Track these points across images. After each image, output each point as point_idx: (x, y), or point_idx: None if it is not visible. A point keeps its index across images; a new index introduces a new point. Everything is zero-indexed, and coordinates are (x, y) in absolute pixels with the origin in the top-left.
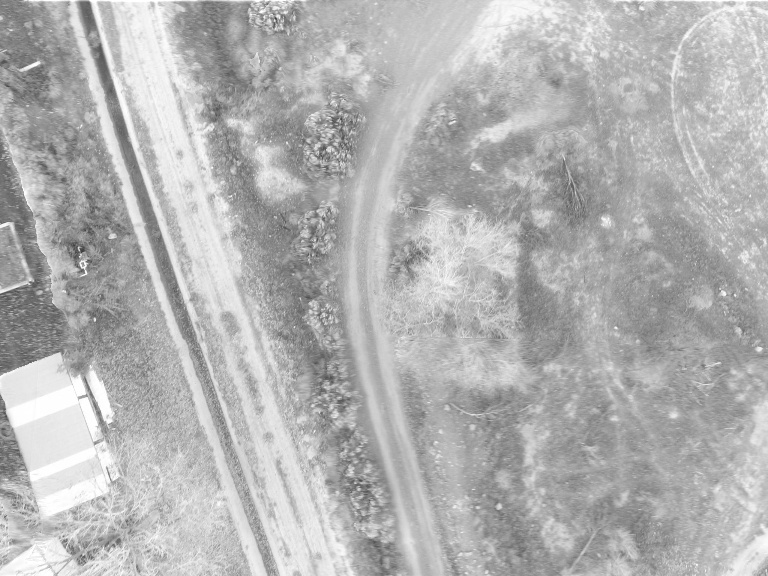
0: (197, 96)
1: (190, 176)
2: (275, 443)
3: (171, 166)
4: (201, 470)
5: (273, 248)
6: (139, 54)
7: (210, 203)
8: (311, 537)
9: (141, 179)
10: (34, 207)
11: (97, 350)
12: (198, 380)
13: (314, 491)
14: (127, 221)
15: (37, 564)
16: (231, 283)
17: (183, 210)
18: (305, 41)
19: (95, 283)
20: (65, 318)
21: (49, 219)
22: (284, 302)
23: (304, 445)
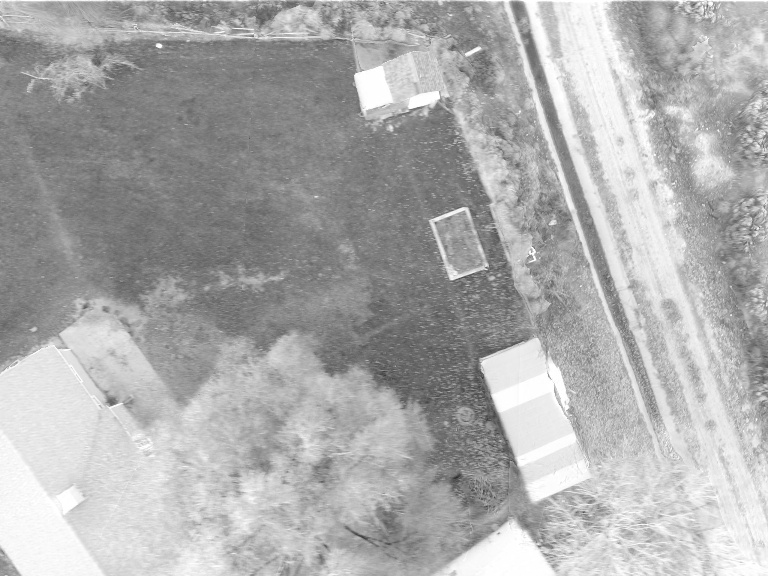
0: (636, 83)
1: (631, 163)
2: (718, 431)
3: (611, 153)
4: (645, 457)
5: (708, 236)
6: (578, 40)
7: (651, 190)
8: (754, 525)
9: (571, 166)
10: (498, 192)
11: (550, 336)
12: (631, 367)
13: (758, 479)
14: (566, 207)
15: (530, 549)
16: (672, 270)
17: (623, 197)
18: (725, 29)
19: (545, 269)
20: (519, 304)
21: (511, 204)
22: (723, 290)
23: (749, 433)
